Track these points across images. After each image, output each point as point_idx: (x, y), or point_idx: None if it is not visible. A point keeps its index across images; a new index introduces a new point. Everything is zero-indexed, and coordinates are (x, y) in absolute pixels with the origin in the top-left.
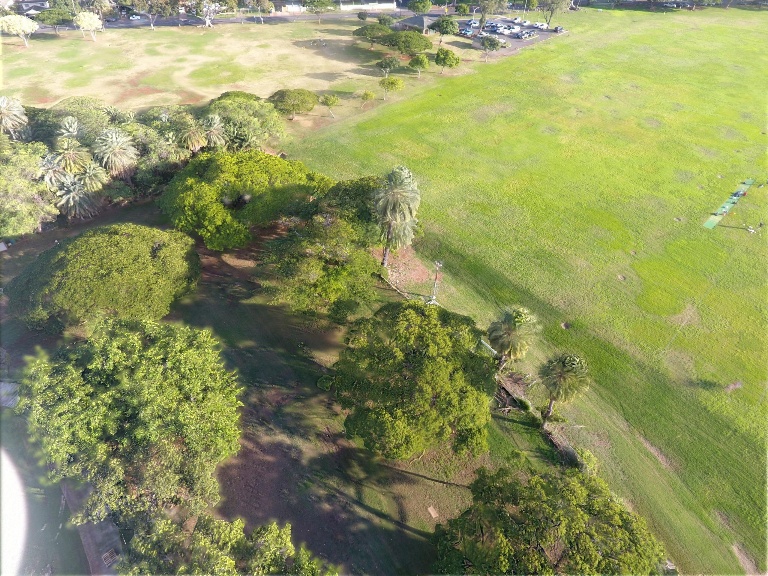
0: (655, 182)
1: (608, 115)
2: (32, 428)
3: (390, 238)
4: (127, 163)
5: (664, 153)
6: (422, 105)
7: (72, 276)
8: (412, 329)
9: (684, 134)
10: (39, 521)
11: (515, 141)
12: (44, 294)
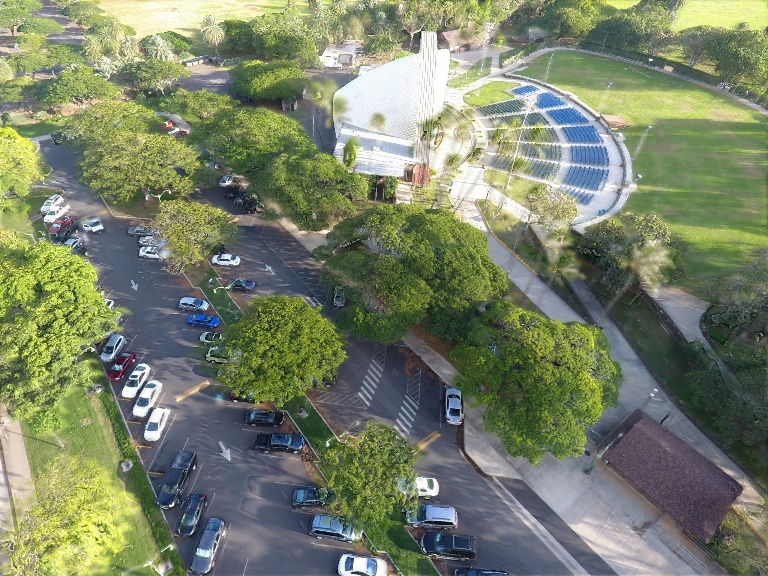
0: (760, 26)
1: (722, 8)
2: (623, 27)
3: (668, 21)
4: (523, 1)
5: (760, 19)
6: (614, 2)
7: (570, 16)
8: (708, 27)
9: (767, 14)
10: (615, 62)
11: (679, 14)
12: (561, 22)
